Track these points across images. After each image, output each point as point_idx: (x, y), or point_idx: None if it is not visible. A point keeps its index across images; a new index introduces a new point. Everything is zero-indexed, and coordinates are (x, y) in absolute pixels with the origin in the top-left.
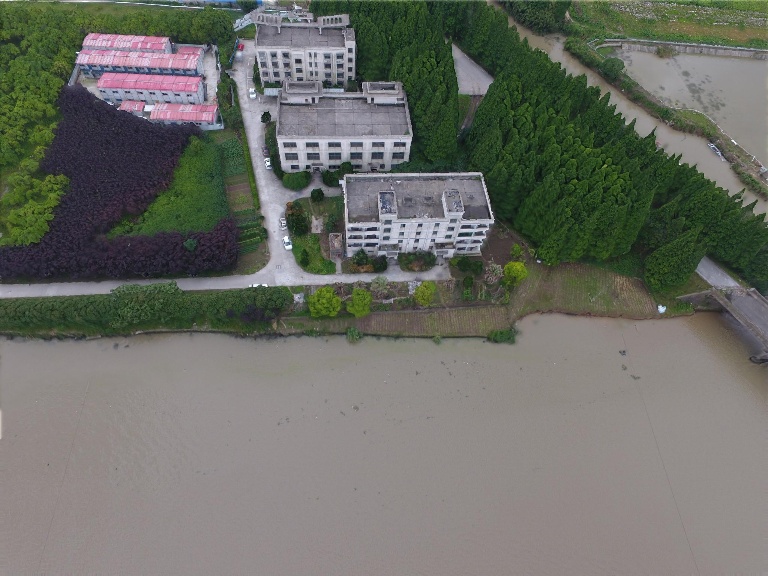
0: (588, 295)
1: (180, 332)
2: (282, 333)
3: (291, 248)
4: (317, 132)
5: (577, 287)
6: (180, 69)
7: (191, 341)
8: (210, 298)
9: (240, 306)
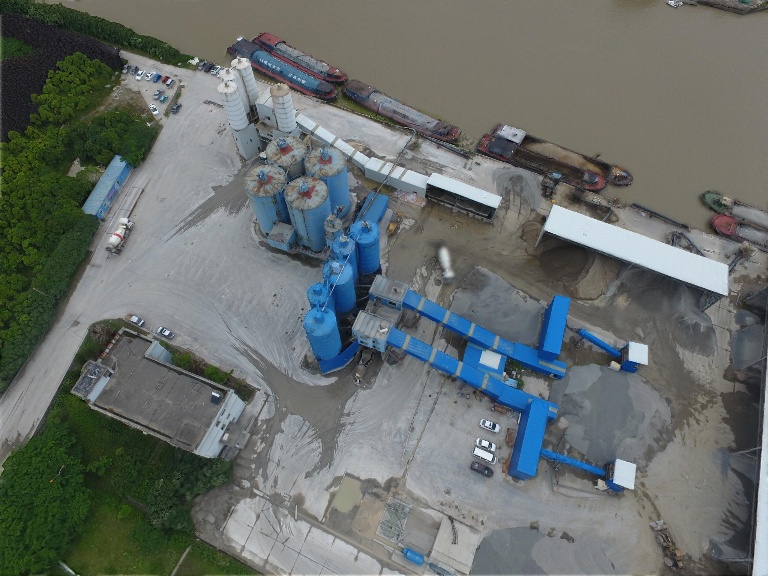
0: None
1: None
2: None
3: None
4: None
5: None
6: None
7: None
8: None
9: None
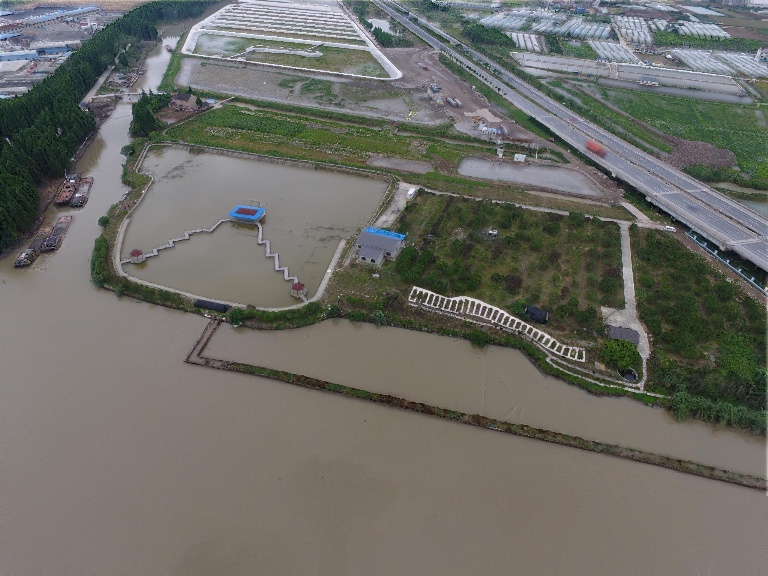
0: None
1: None
2: None
3: None
4: None
5: None
6: None
7: None
8: None
9: None
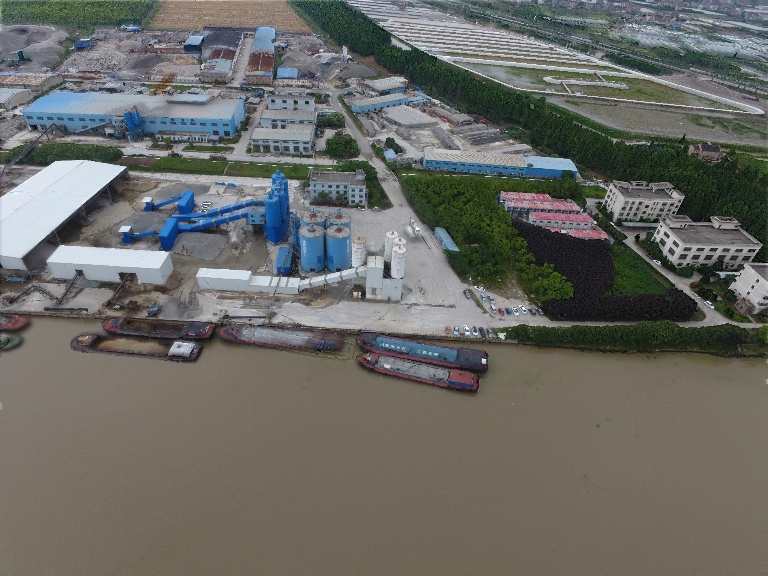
0: None
1: (680, 352)
2: (745, 354)
3: (714, 308)
4: (702, 242)
5: None
6: (568, 211)
7: (690, 357)
8: (703, 329)
9: (725, 333)
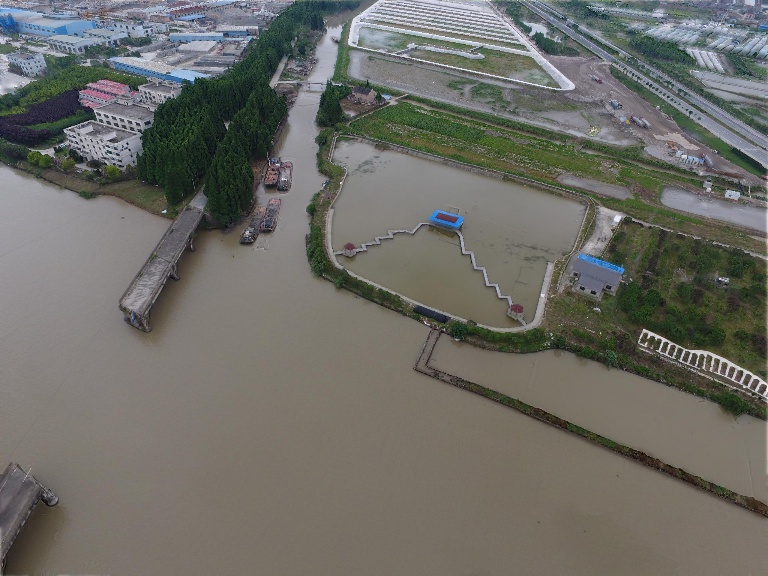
0: (143, 197)
1: None
2: (18, 167)
3: None
4: None
5: (143, 193)
6: None
7: None
8: None
9: None
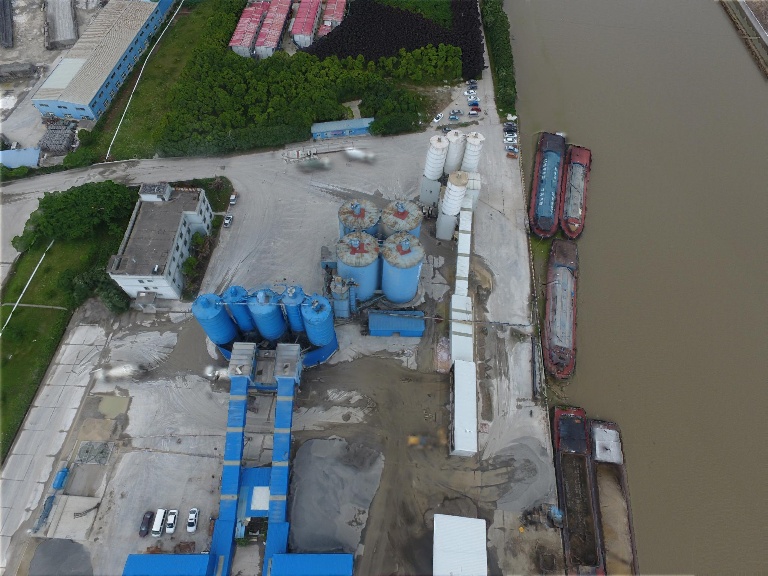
0: None
1: None
2: None
3: None
4: None
5: None
6: None
7: None
8: None
9: None
